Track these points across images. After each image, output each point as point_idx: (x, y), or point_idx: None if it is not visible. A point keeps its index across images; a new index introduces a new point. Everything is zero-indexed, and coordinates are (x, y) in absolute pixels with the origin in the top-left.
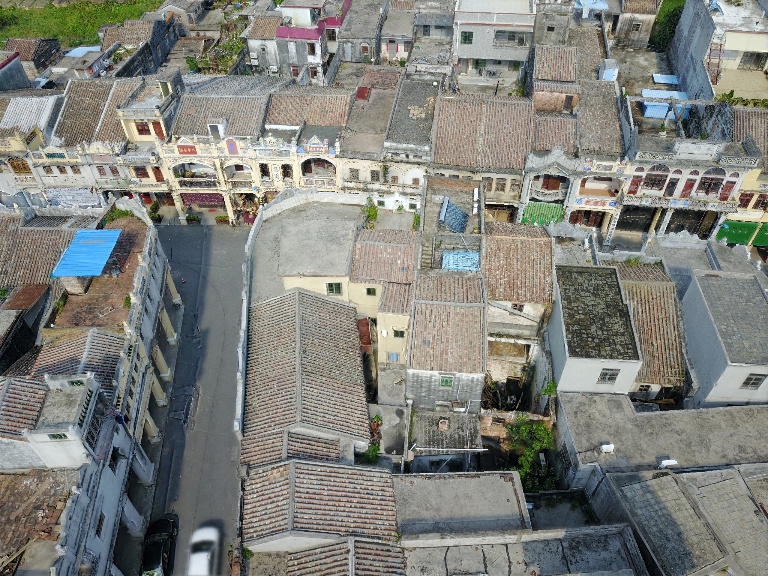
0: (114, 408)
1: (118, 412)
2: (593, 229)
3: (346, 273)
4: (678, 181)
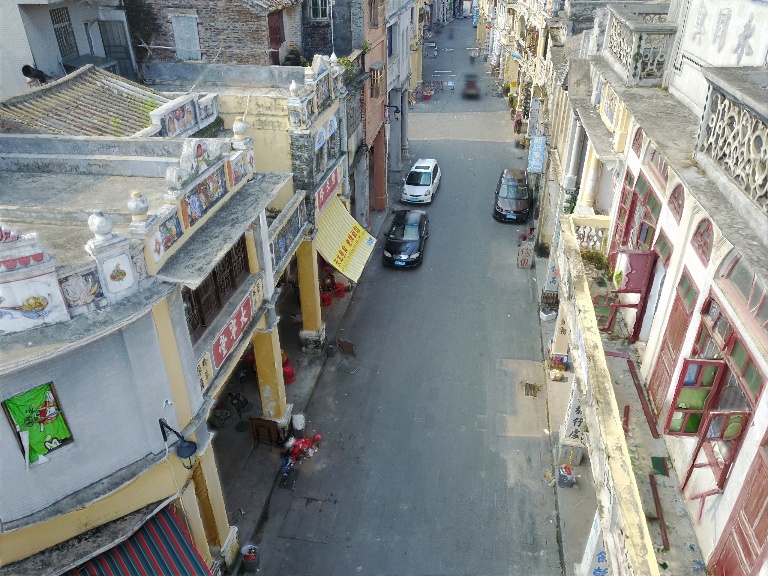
0: None
1: None
2: None
3: None
4: (668, 264)
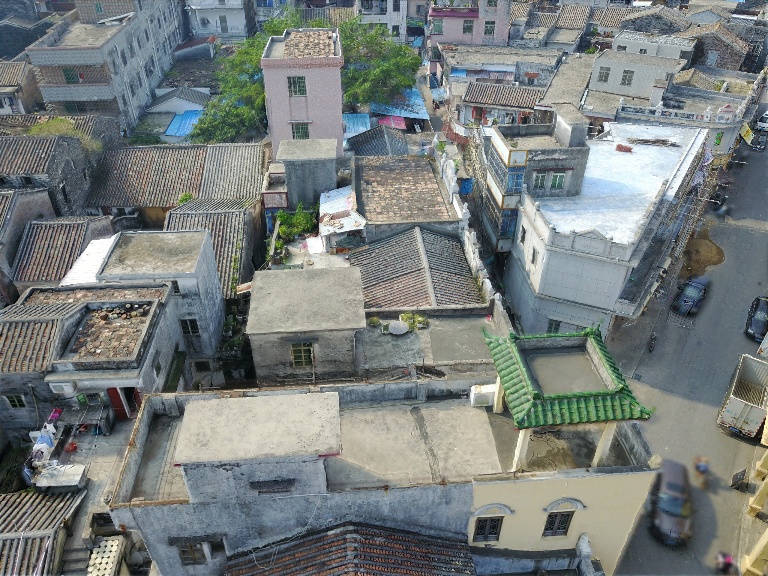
0: (631, 6)
1: (629, 7)
2: (755, 81)
3: (689, 4)
4: None
